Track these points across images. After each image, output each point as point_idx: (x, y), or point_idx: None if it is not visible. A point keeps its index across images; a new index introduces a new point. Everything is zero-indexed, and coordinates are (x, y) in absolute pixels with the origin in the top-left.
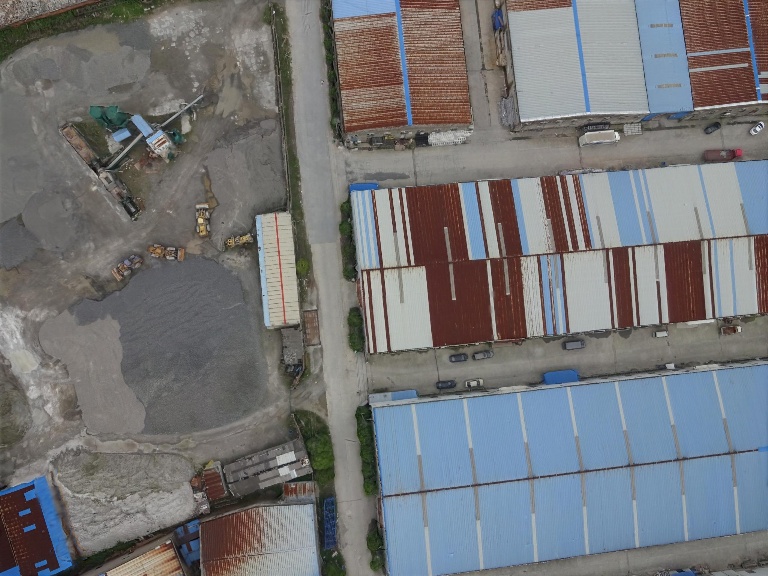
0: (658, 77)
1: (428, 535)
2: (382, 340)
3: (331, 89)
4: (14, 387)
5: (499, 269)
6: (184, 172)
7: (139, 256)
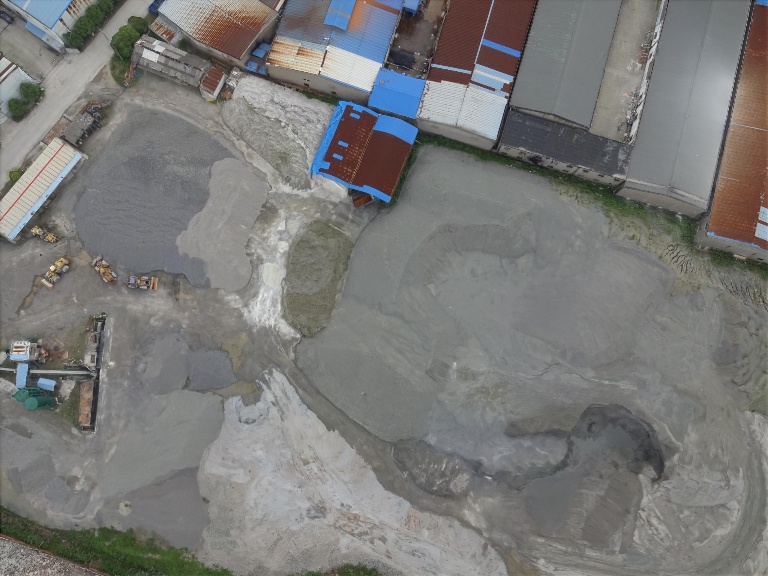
0: None
1: None
2: None
3: None
4: None
5: None
6: (37, 322)
7: (124, 282)
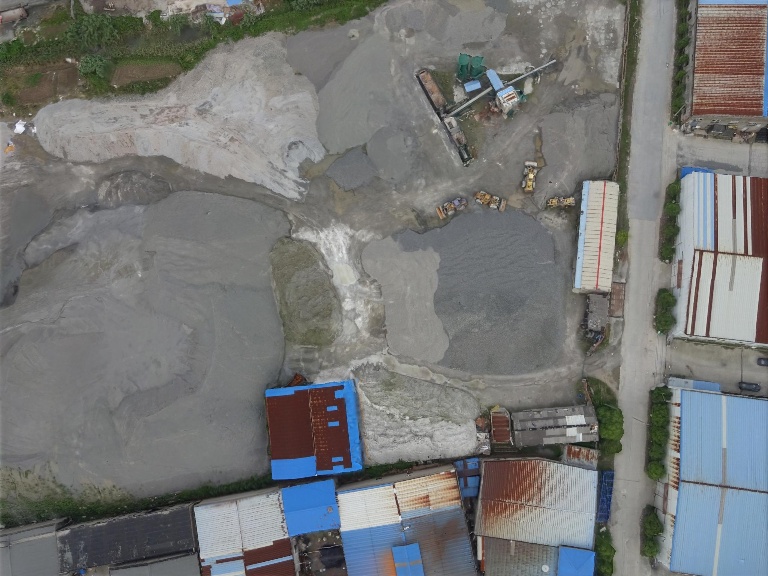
0: None
1: (720, 533)
2: (702, 323)
3: (680, 72)
4: (335, 295)
5: None
6: (519, 130)
7: (465, 199)
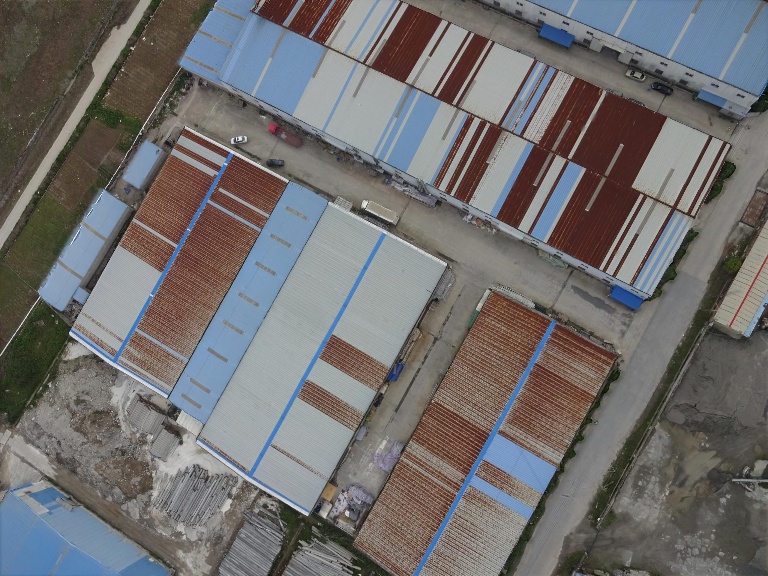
0: (301, 227)
1: None
2: (712, 149)
3: None
4: None
5: (564, 146)
6: None
7: None
